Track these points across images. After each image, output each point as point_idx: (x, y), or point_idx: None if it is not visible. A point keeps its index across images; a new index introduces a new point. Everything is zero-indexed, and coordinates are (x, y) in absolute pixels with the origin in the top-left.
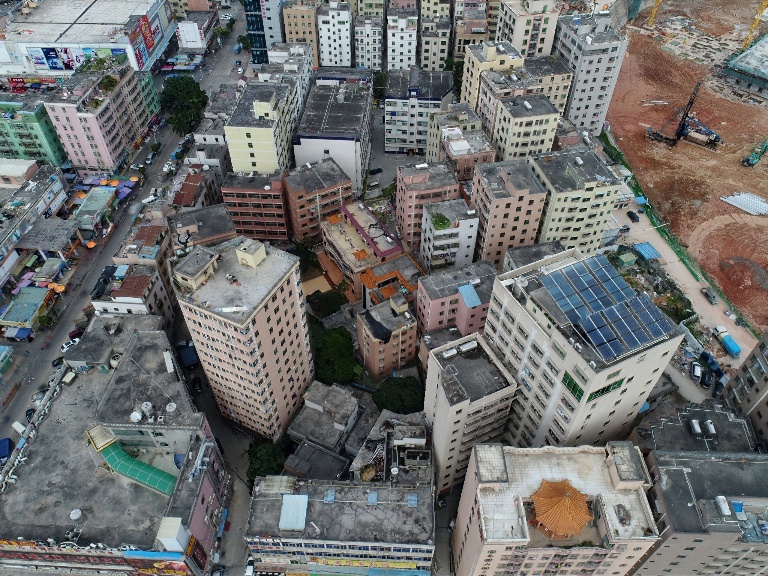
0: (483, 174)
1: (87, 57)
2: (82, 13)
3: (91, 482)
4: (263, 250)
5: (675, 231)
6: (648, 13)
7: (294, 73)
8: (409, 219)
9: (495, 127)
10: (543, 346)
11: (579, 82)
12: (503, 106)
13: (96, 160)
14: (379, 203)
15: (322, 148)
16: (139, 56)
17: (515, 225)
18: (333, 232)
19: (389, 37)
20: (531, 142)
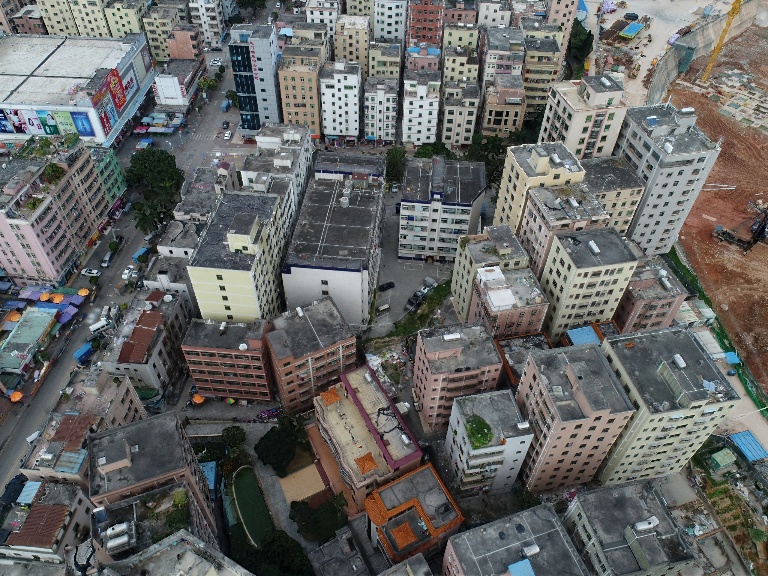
0: (540, 367)
1: (42, 120)
2: (42, 62)
3: None
4: (211, 573)
5: (763, 381)
6: (700, 65)
7: (287, 170)
8: (432, 401)
9: (546, 265)
10: None
11: (651, 197)
12: (561, 246)
13: (35, 269)
14: (390, 349)
15: (319, 278)
16: (105, 119)
17: (584, 443)
18: (329, 413)
19: (405, 105)
20: (596, 293)
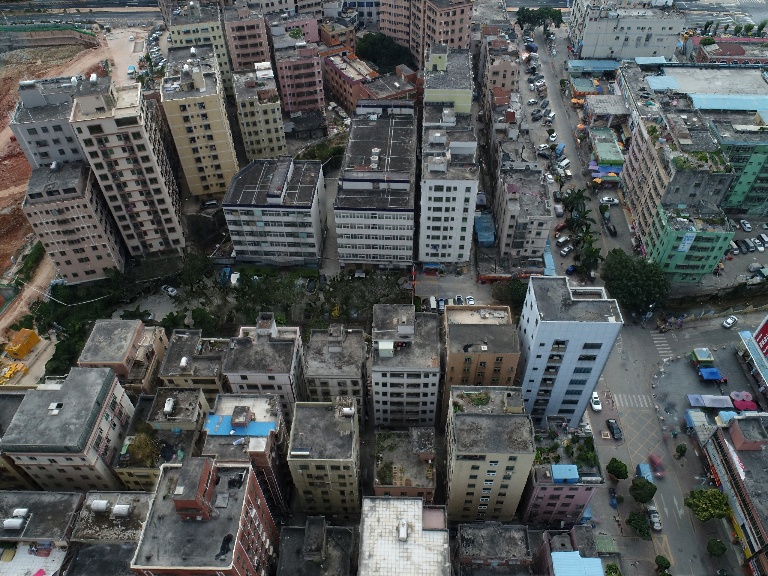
0: None
1: None
2: None
3: None
4: None
5: None
6: None
7: None
8: None
9: None
10: None
11: None
12: None
13: None
14: None
15: None
16: None
17: None
18: None
19: None
20: None
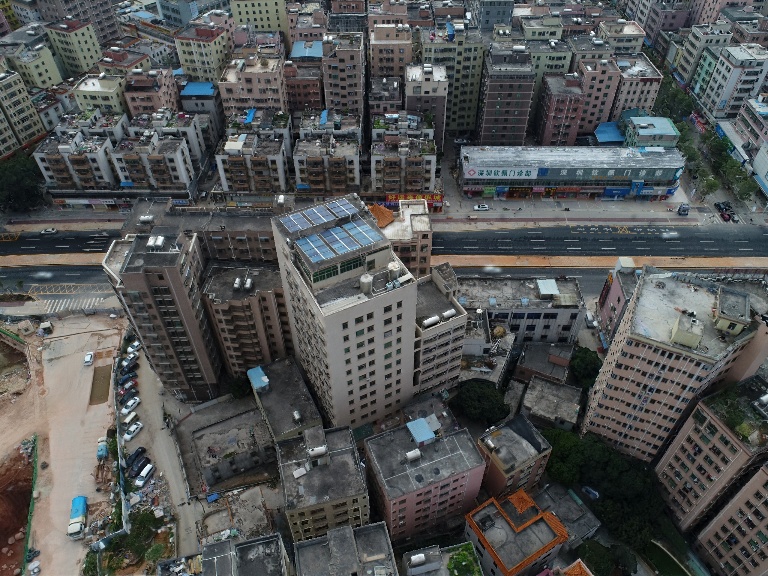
0: None
1: None
2: None
3: None
4: None
5: None
6: None
7: None
8: None
9: None
10: None
11: None
12: None
13: None
14: None
15: None
16: None
17: None
18: None
19: None
20: None
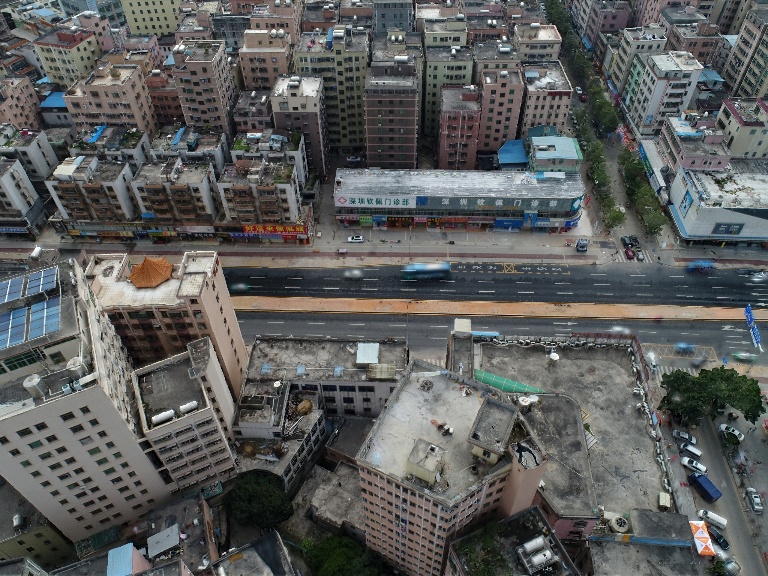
0: None
1: None
2: None
3: (563, 392)
4: None
5: None
6: None
7: None
8: None
9: None
10: (95, 323)
11: None
12: None
13: None
14: None
15: None
16: None
17: None
18: None
19: None
20: None
